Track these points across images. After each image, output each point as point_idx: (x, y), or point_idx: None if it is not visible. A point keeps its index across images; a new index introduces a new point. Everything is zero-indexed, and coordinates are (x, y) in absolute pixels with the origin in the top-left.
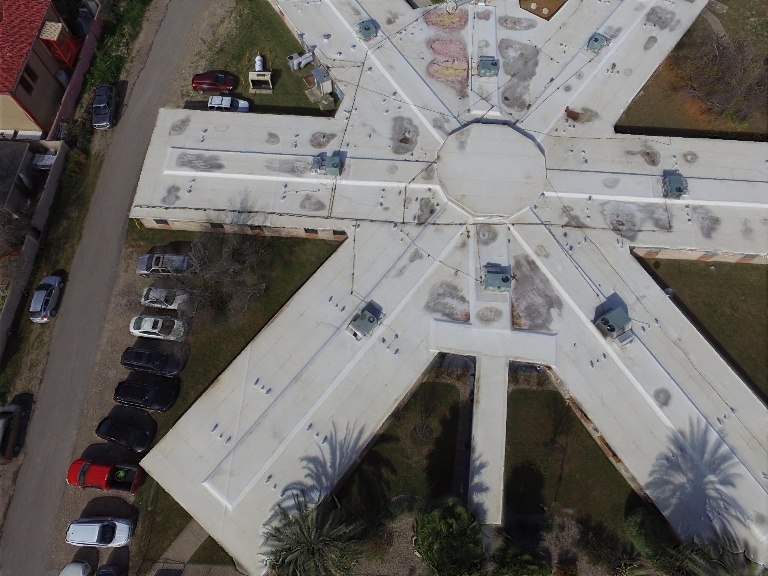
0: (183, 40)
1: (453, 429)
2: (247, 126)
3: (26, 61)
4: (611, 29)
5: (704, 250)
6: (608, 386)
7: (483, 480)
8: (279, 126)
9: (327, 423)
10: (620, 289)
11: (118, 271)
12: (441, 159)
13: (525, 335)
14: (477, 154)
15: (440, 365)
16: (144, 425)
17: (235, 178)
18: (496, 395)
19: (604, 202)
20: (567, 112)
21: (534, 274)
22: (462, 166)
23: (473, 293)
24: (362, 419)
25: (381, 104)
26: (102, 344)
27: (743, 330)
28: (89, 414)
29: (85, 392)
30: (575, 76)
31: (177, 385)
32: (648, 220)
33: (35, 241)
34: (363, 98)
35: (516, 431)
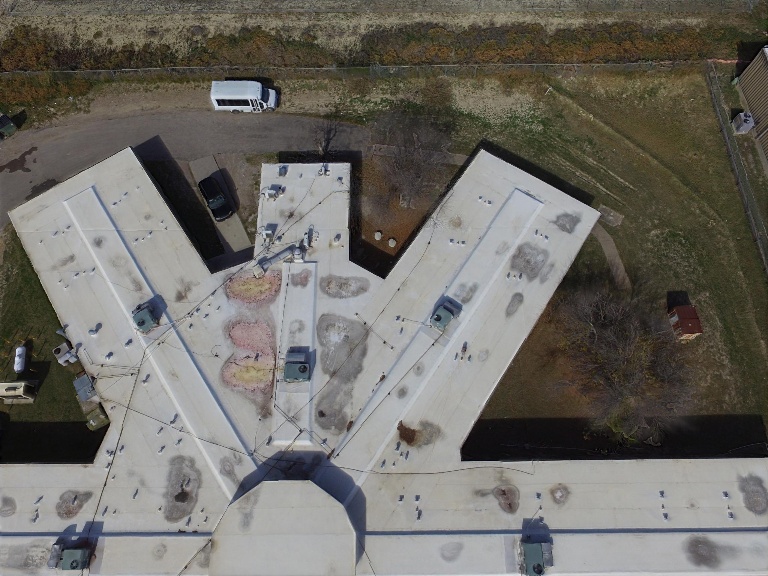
0: None
1: None
2: None
3: None
4: (463, 288)
5: None
6: None
7: None
8: (17, 485)
9: None
10: None
11: None
12: (215, 548)
13: None
14: (264, 536)
15: None
16: None
17: None
18: None
19: None
20: (400, 430)
21: None
22: (242, 559)
23: None
24: None
25: (155, 437)
26: None
27: None
28: None
29: None
30: (412, 371)
31: None
32: None
33: None
34: (133, 427)
35: None
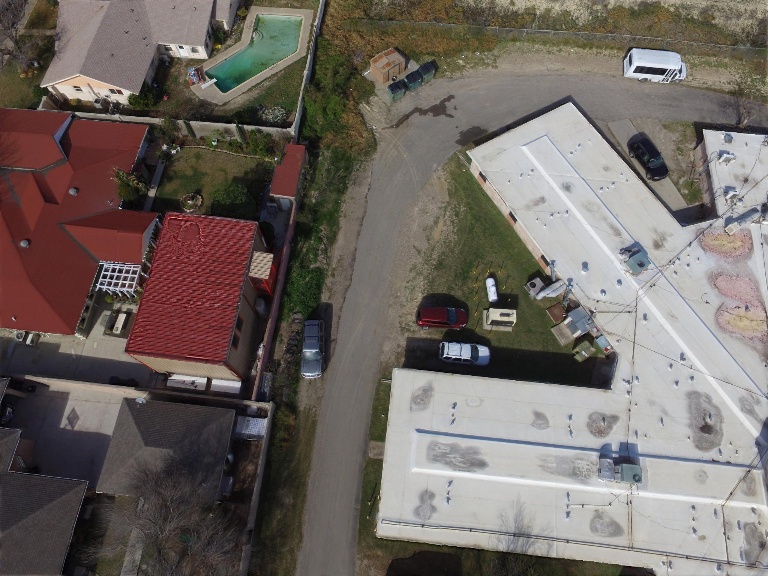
0: (392, 247)
1: None
2: (506, 400)
3: (237, 313)
4: None
5: None
6: None
7: None
8: (546, 402)
9: None
10: None
11: None
12: None
13: None
14: None
15: None
16: None
17: (503, 482)
18: None
19: None
20: None
21: None
22: None
23: None
24: None
25: (668, 372)
26: None
27: None
28: None
29: None
30: None
31: None
32: None
33: (248, 546)
34: (643, 361)
35: None
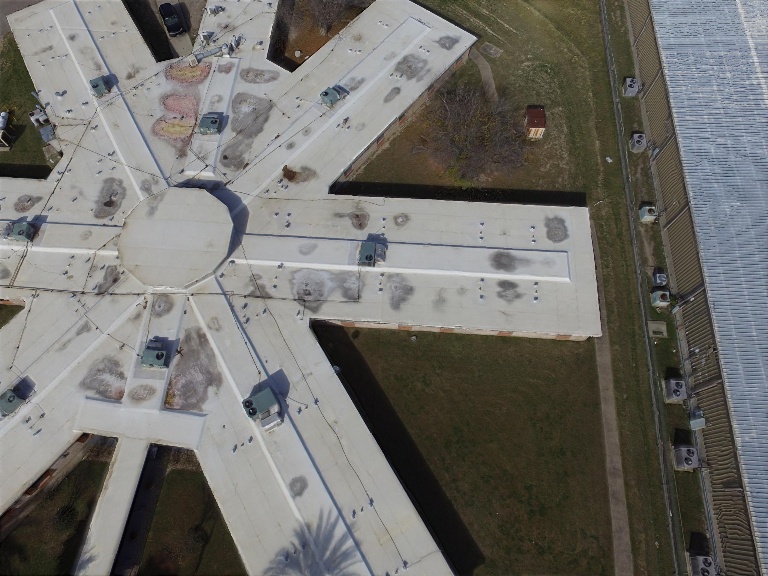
0: None
1: None
2: None
3: None
4: (353, 81)
5: (388, 323)
6: (247, 473)
7: (88, 575)
8: None
9: None
10: (287, 365)
11: None
12: (126, 226)
13: (173, 416)
14: (164, 221)
15: (104, 442)
16: None
17: None
18: (126, 481)
19: (296, 270)
20: (284, 171)
21: (201, 349)
22: (145, 234)
23: (132, 369)
24: None
25: (96, 165)
26: None
27: (431, 407)
28: None
29: None
30: (301, 132)
31: None
32: (337, 289)
33: None
34: (80, 158)
35: (164, 515)
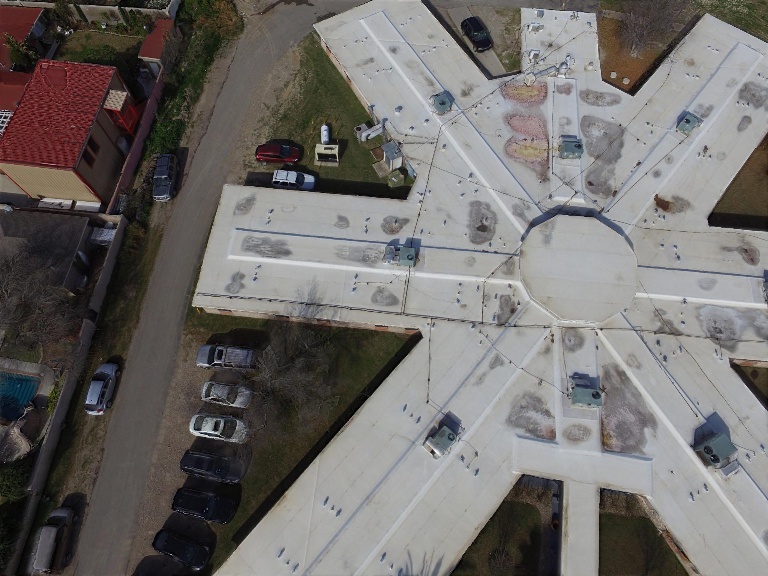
0: (245, 105)
1: (535, 558)
2: (315, 207)
3: (90, 134)
4: (701, 107)
5: None
6: (710, 523)
7: None
8: (349, 208)
9: (402, 553)
10: (720, 408)
11: (177, 360)
12: (524, 255)
13: (617, 459)
14: (563, 250)
15: (519, 482)
16: (203, 537)
17: (303, 265)
18: (587, 529)
19: (700, 306)
20: (656, 200)
21: (625, 387)
22: (547, 263)
23: (559, 408)
24: (440, 550)
25: (456, 186)
26: (159, 442)
27: None
28: (145, 521)
29: (141, 496)
30: (664, 160)
31: (238, 493)
32: (749, 328)
33: (92, 323)
34: (437, 179)
35: (604, 563)
